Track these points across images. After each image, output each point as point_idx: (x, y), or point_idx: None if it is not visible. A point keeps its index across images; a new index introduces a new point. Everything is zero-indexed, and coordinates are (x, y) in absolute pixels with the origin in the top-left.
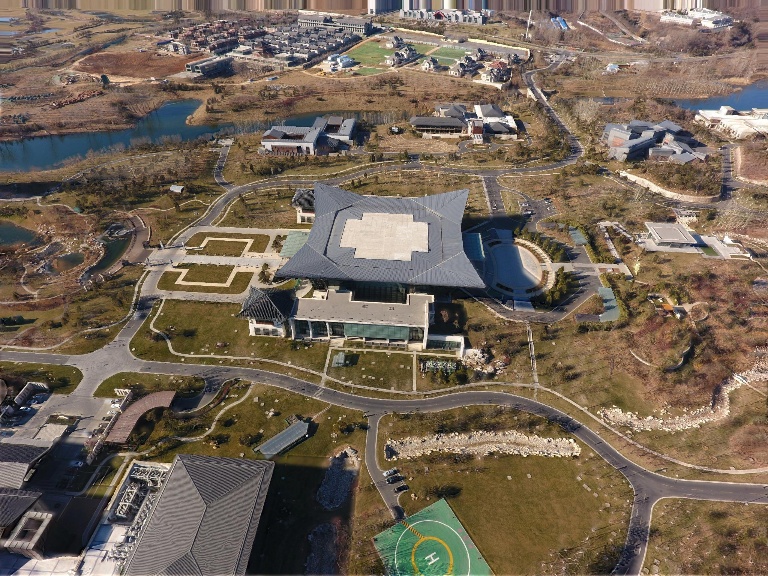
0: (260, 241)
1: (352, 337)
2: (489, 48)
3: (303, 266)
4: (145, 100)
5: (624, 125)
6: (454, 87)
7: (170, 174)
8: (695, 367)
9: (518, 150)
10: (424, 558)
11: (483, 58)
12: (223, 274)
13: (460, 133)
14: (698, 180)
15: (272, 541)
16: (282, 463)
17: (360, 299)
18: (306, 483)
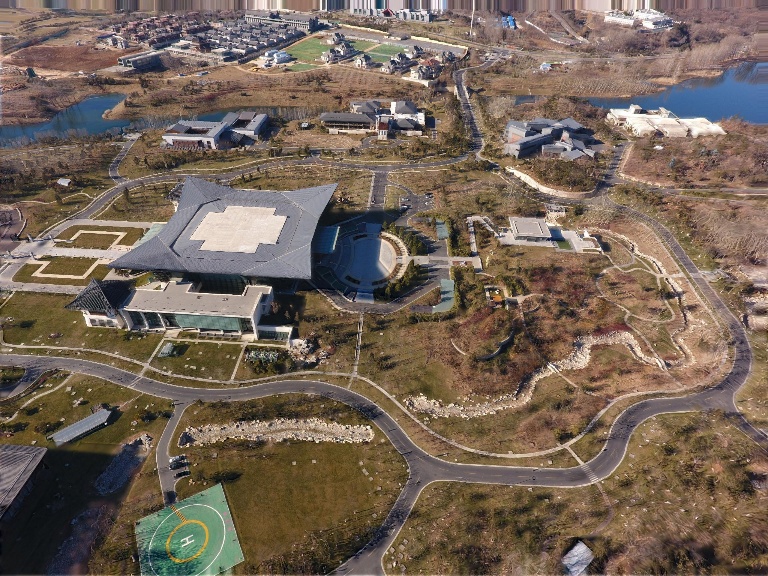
0: (133, 234)
1: (188, 328)
2: (429, 46)
3: (141, 258)
4: (66, 94)
5: (525, 122)
6: (381, 84)
7: (61, 167)
8: (511, 356)
9: (418, 146)
10: (179, 540)
11: (420, 55)
12: (83, 266)
13: (367, 129)
14: (577, 176)
15: (33, 526)
16: (71, 450)
17: (209, 291)
18: (89, 469)
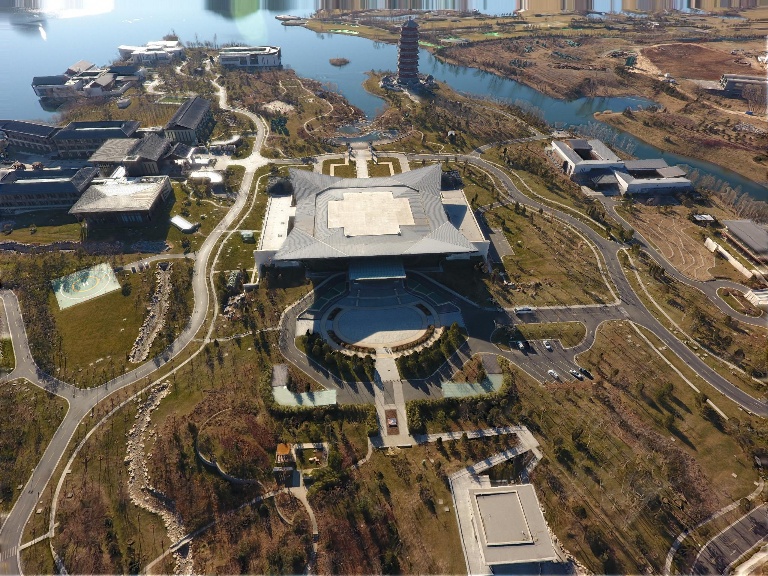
0: None
1: None
2: None
3: (306, 179)
4: None
5: None
6: None
7: (466, 124)
8: None
9: None
10: (87, 281)
11: None
12: (345, 177)
13: None
14: None
15: (120, 230)
16: (165, 225)
17: None
18: (151, 236)
